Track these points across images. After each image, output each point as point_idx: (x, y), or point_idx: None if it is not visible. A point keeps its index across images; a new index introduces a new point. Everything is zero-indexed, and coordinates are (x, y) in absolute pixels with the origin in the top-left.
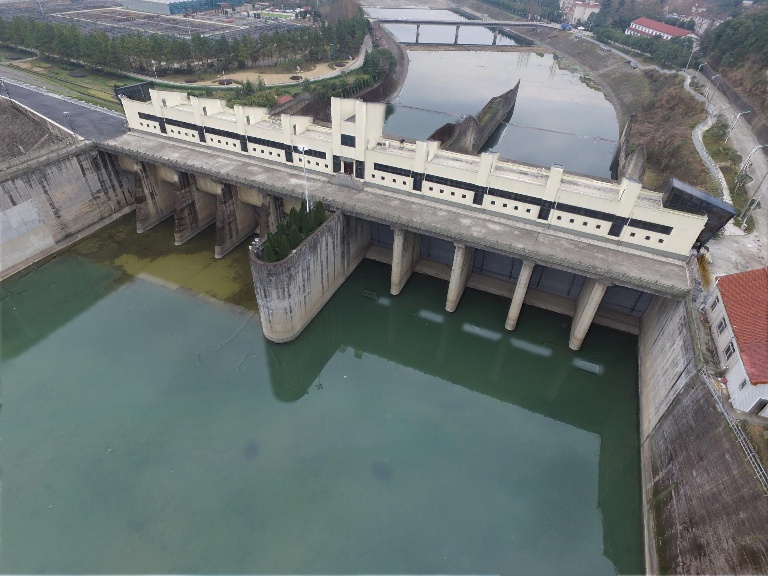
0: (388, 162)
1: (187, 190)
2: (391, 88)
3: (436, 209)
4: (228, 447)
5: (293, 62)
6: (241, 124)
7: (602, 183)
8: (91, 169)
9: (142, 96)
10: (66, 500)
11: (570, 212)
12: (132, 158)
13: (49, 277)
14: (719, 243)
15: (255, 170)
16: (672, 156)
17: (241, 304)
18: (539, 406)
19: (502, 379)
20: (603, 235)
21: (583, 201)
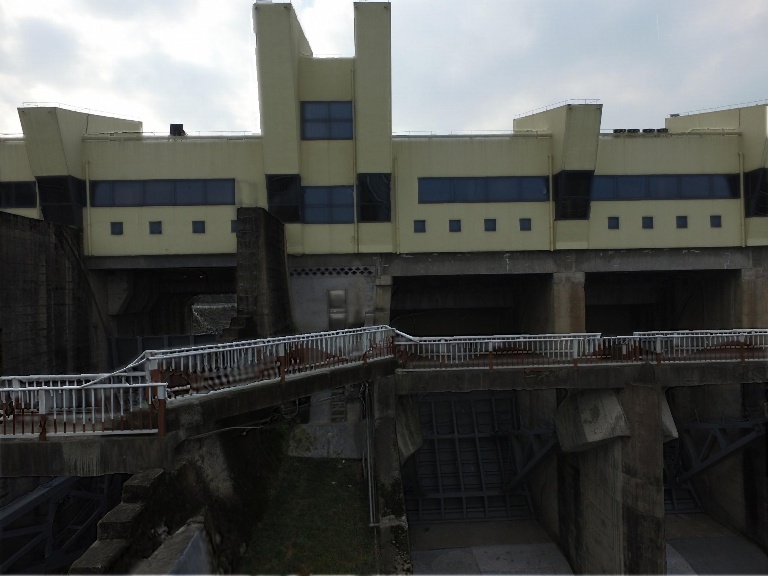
0: None
1: None
2: None
3: None
4: None
5: None
6: None
7: None
8: None
9: None
10: None
11: None
12: None
13: None
14: None
15: None
16: None
17: None
18: None
19: None
20: None
21: None
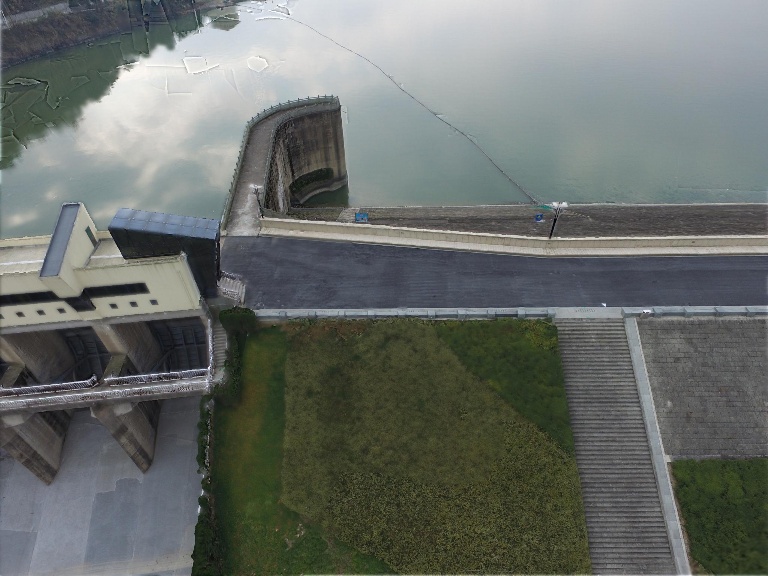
0: None
1: None
2: None
3: None
4: None
5: None
6: None
7: None
8: None
9: None
10: (65, 182)
11: None
12: None
13: None
14: None
15: None
16: None
17: None
18: None
19: None
20: None
21: None
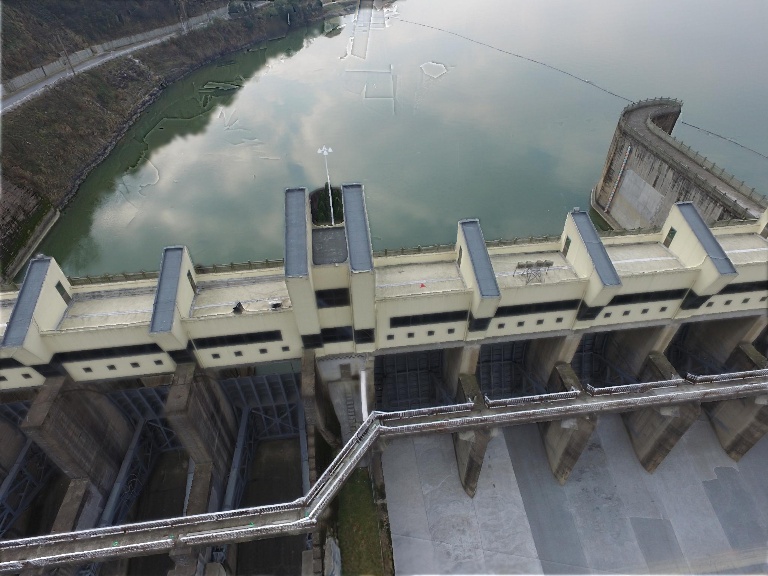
0: None
1: None
2: None
3: None
4: None
5: None
6: None
7: None
8: None
9: None
10: None
11: None
12: None
13: None
14: None
15: None
16: None
17: None
18: None
19: None
20: None
21: None
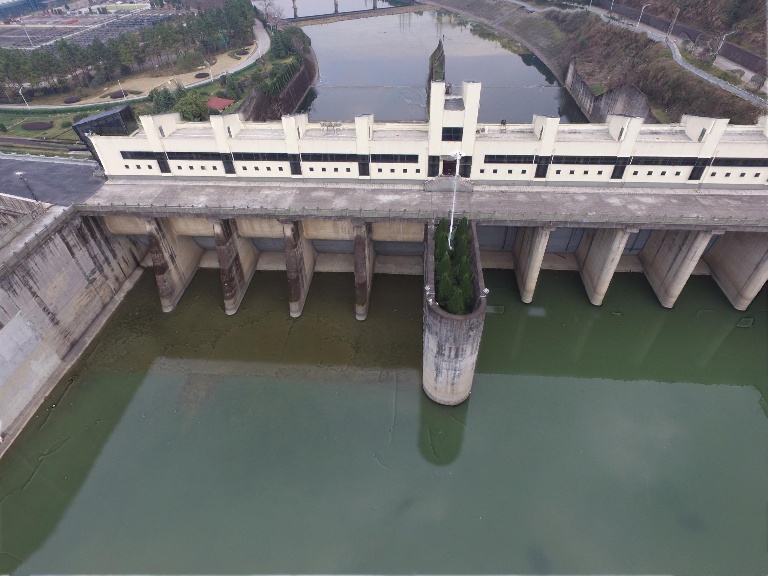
0: (504, 151)
1: (230, 241)
2: (311, 70)
3: (570, 194)
4: (510, 570)
5: (190, 58)
6: (292, 140)
7: (744, 127)
8: (78, 244)
9: (122, 128)
10: None
11: (727, 165)
12: (143, 216)
13: (83, 412)
14: None
15: (324, 195)
16: (674, 88)
17: (372, 368)
18: (689, 376)
19: (649, 360)
20: (761, 183)
21: (745, 150)
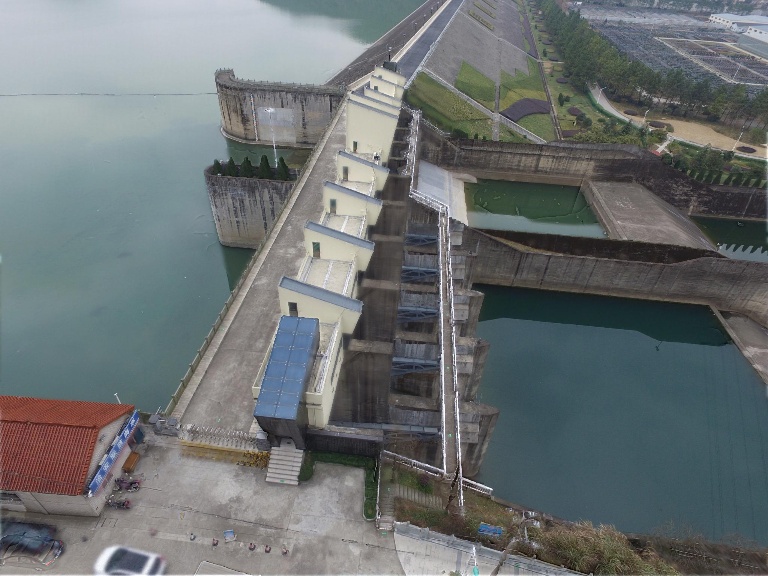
0: None
1: None
2: None
3: None
4: None
5: None
6: None
7: None
8: None
9: None
10: (101, 213)
11: None
12: None
13: None
14: (352, 516)
15: None
16: None
17: None
18: None
19: None
20: None
21: None
